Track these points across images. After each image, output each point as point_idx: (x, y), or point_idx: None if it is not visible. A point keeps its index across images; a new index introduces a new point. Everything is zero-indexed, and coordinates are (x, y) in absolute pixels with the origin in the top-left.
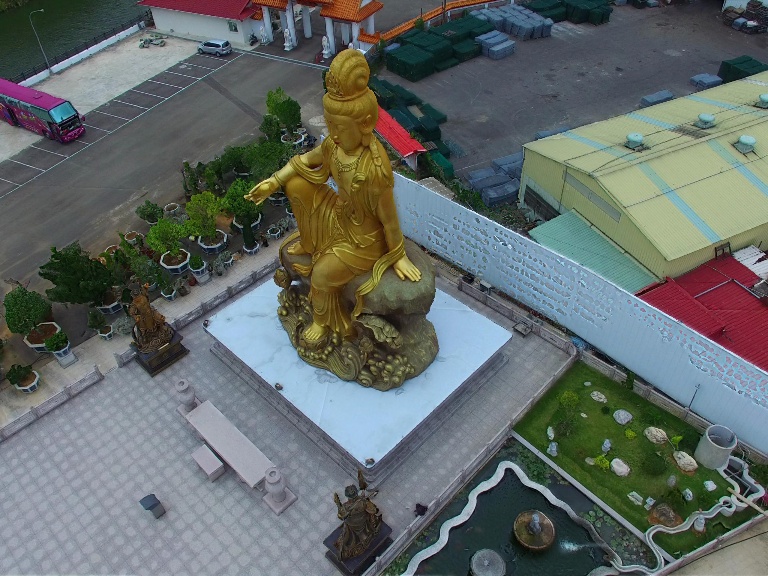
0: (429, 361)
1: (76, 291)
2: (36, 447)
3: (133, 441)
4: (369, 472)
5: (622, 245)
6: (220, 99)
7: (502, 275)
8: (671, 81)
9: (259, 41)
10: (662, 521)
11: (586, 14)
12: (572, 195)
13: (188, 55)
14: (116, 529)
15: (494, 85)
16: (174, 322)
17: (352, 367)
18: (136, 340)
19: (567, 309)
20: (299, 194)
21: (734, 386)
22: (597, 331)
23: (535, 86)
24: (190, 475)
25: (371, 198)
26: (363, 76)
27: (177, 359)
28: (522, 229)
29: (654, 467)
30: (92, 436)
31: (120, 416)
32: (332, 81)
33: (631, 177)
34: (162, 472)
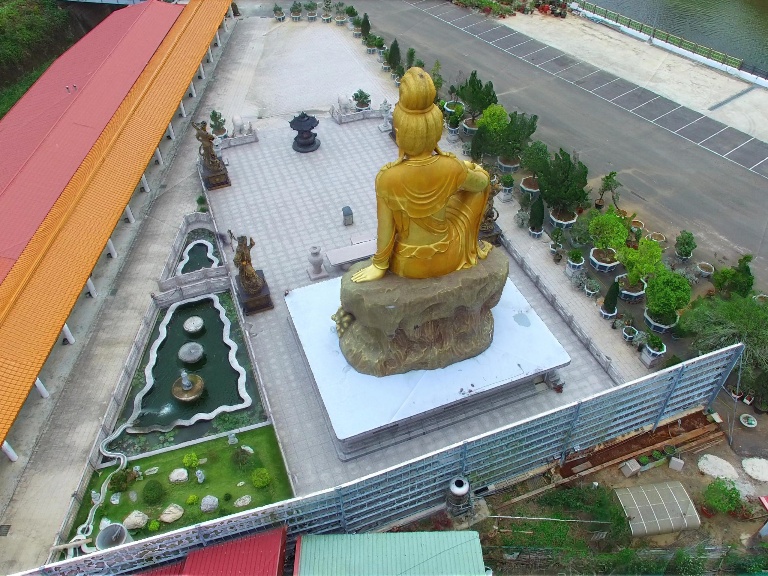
0: None
1: None
2: None
3: None
4: None
5: None
6: None
7: None
8: None
9: None
10: None
11: None
12: None
13: None
14: None
15: None
16: None
17: None
18: None
19: None
20: None
21: (126, 575)
22: None
23: None
24: None
25: None
26: None
27: None
28: None
29: (149, 481)
30: None
31: None
32: None
33: None
34: None
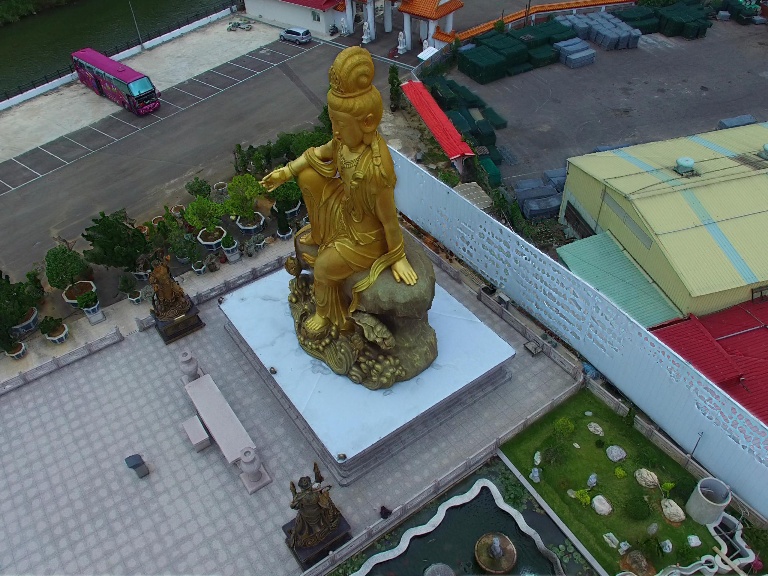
0: (423, 366)
1: (111, 255)
2: (52, 394)
3: (136, 402)
4: (344, 467)
5: (651, 274)
6: (290, 86)
7: (521, 290)
8: (760, 105)
9: (339, 32)
10: (634, 569)
11: (680, 27)
12: (608, 216)
13: (270, 41)
14: (103, 481)
15: (565, 94)
16: (196, 295)
17: (344, 362)
18: (155, 308)
19: (581, 333)
20: (309, 185)
21: (739, 439)
22: (608, 360)
23: (608, 99)
24: (179, 442)
25: (369, 197)
26: (365, 74)
27: (192, 331)
28: (558, 245)
29: (635, 511)
30: (101, 392)
31: (130, 377)
32: (333, 77)
33: (671, 203)
34: (155, 435)
